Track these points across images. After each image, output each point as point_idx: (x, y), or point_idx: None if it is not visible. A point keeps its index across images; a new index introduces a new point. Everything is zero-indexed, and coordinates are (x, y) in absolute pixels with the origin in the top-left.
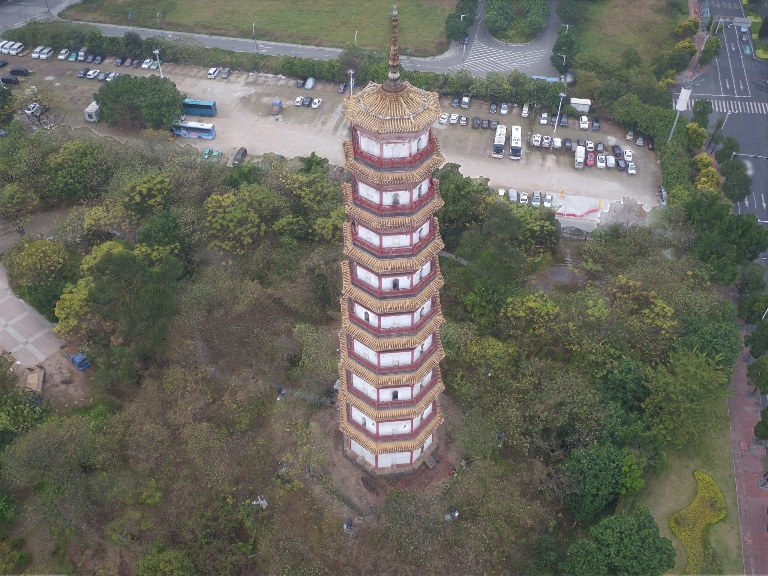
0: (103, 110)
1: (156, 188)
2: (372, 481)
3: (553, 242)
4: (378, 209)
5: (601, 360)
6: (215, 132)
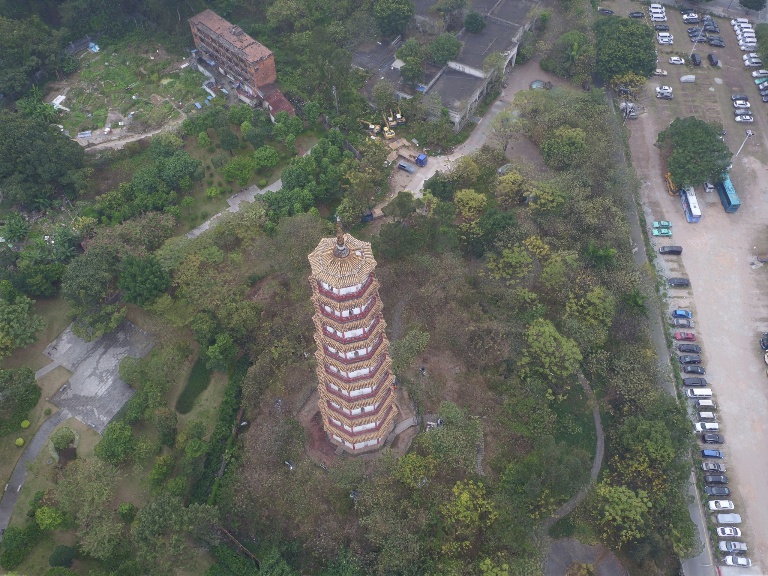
0: (661, 132)
1: (541, 201)
2: (321, 415)
3: (633, 553)
4: None
5: (440, 575)
6: (698, 220)
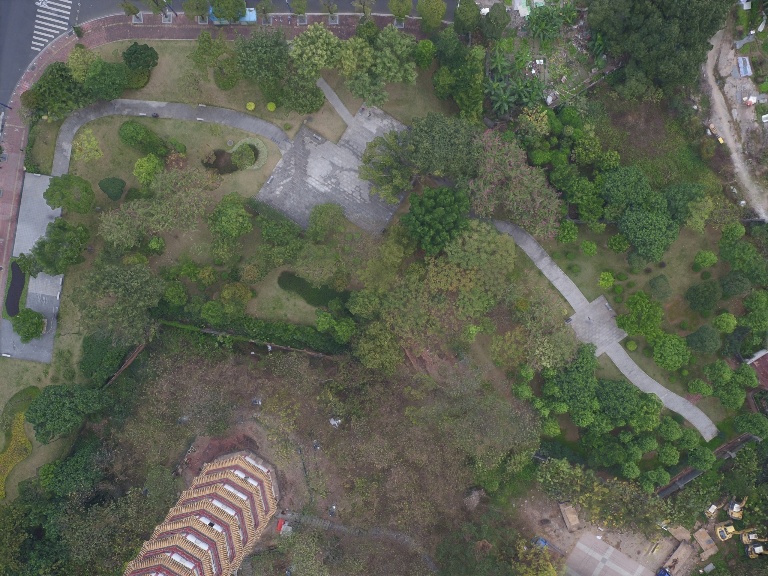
0: None
1: None
2: (250, 446)
3: None
4: (161, 568)
5: None
6: None
